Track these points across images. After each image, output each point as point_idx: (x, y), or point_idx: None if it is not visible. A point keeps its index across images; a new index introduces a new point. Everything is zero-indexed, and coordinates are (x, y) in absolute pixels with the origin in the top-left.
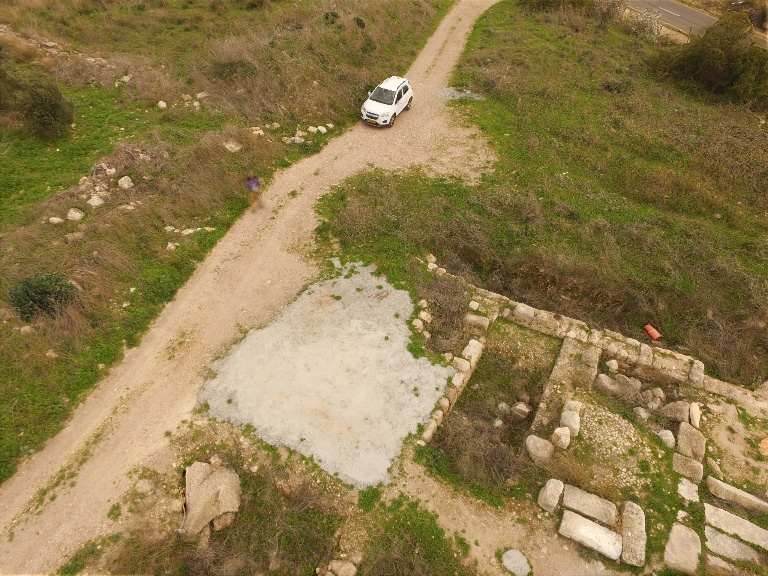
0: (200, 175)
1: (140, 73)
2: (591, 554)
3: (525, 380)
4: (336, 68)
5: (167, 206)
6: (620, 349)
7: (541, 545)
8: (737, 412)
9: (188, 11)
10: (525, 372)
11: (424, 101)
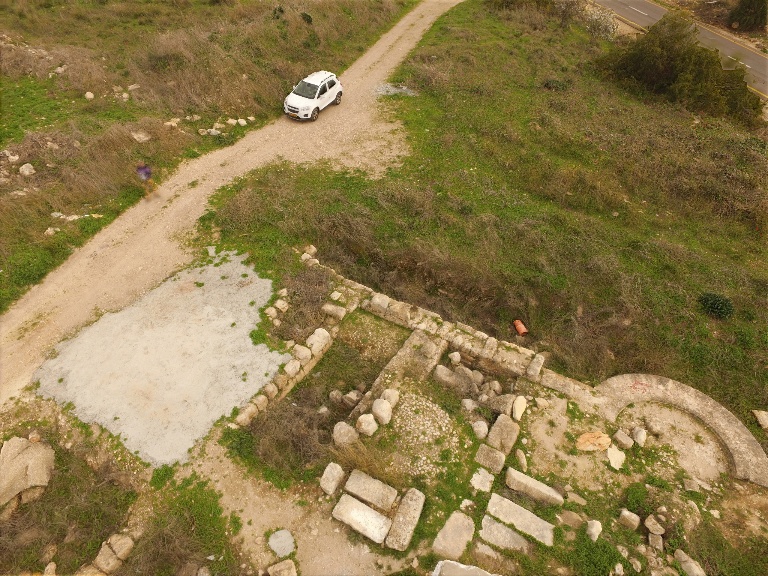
0: (100, 164)
1: (75, 65)
2: (358, 537)
3: (364, 369)
4: (271, 62)
5: (61, 193)
6: (465, 342)
7: (313, 527)
8: (566, 407)
9: (146, 5)
10: (369, 362)
11: (357, 96)
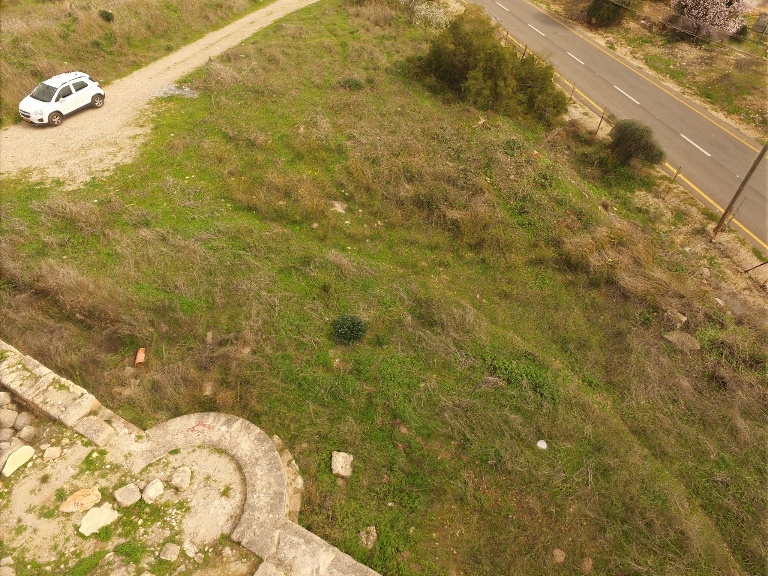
0: None
1: None
2: None
3: None
4: (36, 63)
5: None
6: (16, 380)
7: None
8: (85, 456)
9: None
10: None
11: (128, 98)
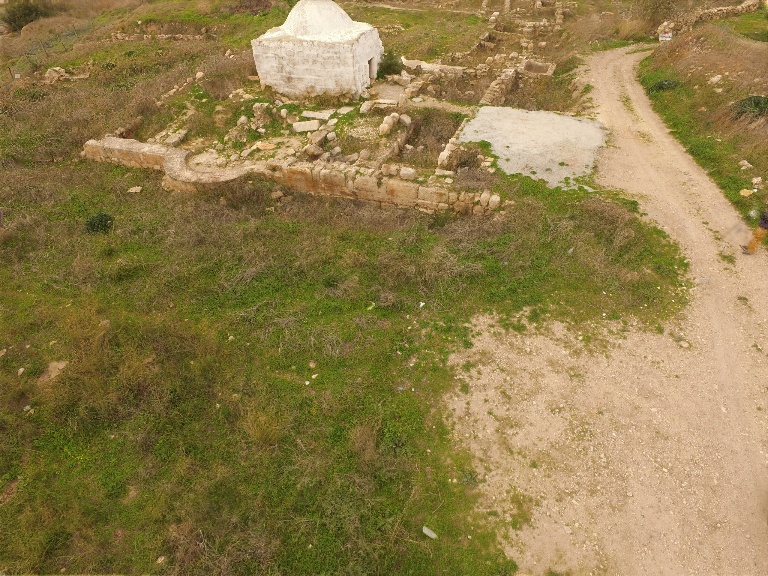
0: None
1: None
2: None
3: None
4: None
5: None
6: (338, 166)
7: None
8: None
9: None
10: None
11: None
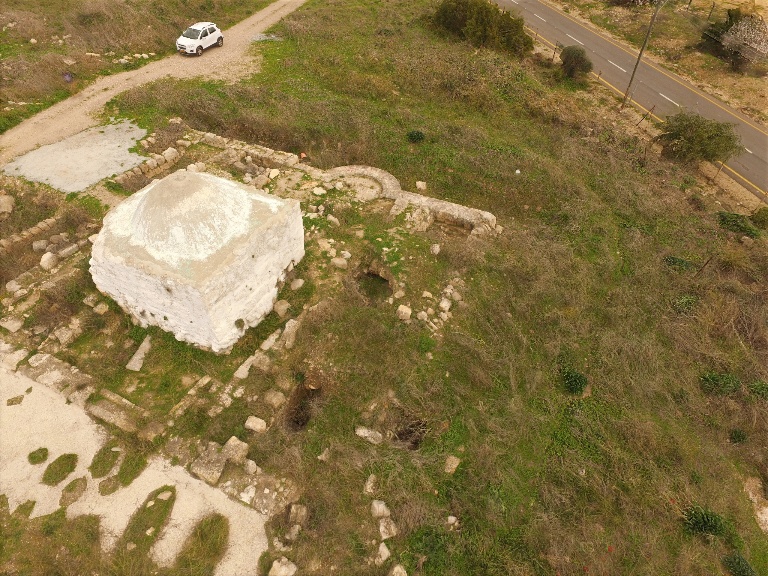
0: (40, 76)
1: None
2: None
3: None
4: None
5: None
6: (255, 151)
7: None
8: (303, 175)
9: None
10: None
11: (236, 42)
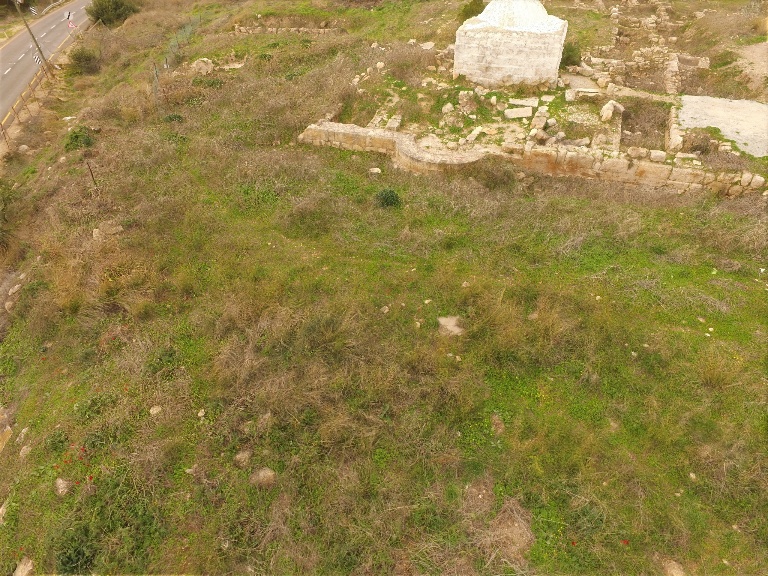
0: None
1: None
2: None
3: None
4: None
5: None
6: (581, 149)
7: None
8: None
9: None
10: None
11: None
